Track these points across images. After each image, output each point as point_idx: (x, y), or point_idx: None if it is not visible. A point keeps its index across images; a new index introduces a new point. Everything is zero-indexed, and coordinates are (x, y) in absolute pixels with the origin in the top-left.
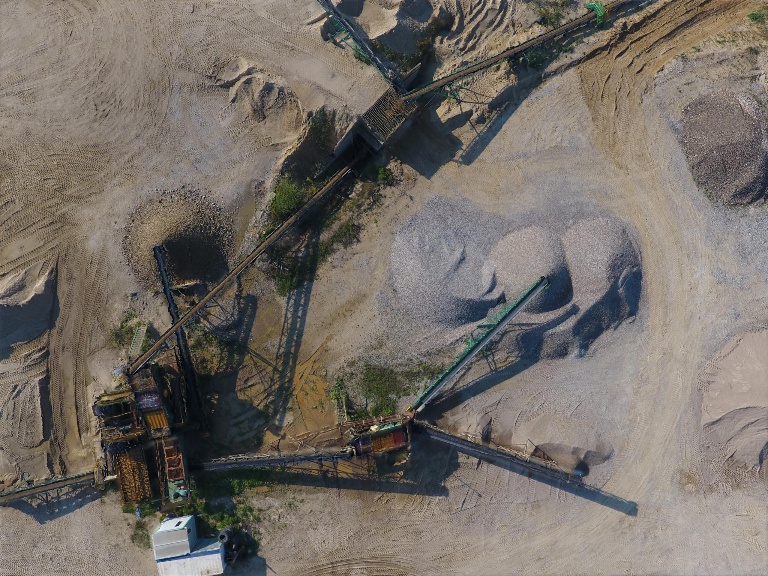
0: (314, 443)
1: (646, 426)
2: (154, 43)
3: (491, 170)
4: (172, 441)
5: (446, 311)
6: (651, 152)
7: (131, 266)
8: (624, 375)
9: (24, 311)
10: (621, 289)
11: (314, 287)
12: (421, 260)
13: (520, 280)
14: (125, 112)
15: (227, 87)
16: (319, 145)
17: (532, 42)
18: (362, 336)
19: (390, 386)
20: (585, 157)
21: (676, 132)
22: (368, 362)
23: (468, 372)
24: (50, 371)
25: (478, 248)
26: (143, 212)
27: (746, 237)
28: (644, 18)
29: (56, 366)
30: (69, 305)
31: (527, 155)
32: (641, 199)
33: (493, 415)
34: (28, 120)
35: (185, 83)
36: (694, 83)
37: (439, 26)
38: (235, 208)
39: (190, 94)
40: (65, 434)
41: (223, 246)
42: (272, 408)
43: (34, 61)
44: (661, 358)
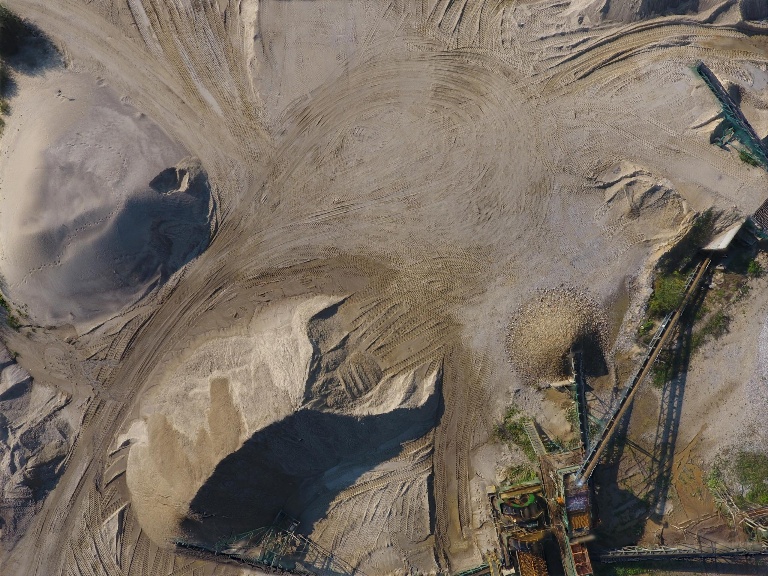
0: (696, 531)
1: None
2: (537, 148)
3: None
4: (576, 537)
5: None
6: None
7: (514, 363)
8: None
9: (420, 412)
10: None
11: (688, 378)
12: None
13: None
14: (507, 215)
15: (604, 188)
16: (694, 241)
17: None
18: (735, 424)
19: (764, 472)
20: None
21: None
22: (742, 449)
23: None
24: (435, 467)
25: None
26: (526, 311)
27: None
28: None
29: (440, 462)
30: (453, 403)
31: None
32: None
33: None
34: (413, 225)
35: (565, 185)
36: None
37: None
38: (610, 304)
39: (569, 195)
40: (447, 527)
41: (601, 341)
42: (652, 497)
43: (419, 168)
44: None
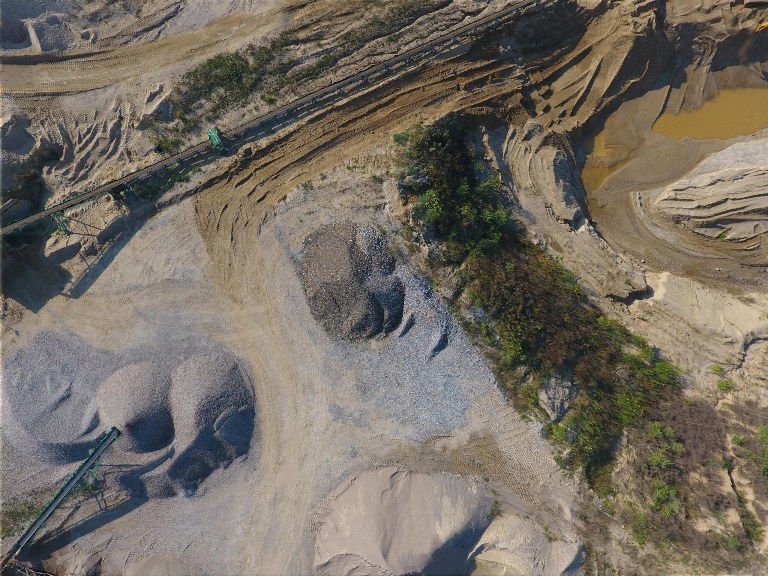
0: None
1: (256, 568)
2: None
3: (100, 304)
4: None
5: (42, 453)
6: (267, 285)
7: None
8: (235, 515)
9: None
10: (217, 432)
11: None
12: (13, 401)
13: (111, 423)
14: None
15: None
16: None
17: (134, 175)
18: None
19: None
20: (198, 290)
21: (295, 264)
22: None
23: (77, 511)
24: None
25: (86, 384)
26: None
27: (367, 371)
28: (271, 143)
29: None
30: None
31: (138, 288)
32: (256, 333)
33: (103, 555)
34: None
35: None
36: (316, 212)
37: (40, 158)
38: None
39: None
40: None
41: None
42: None
43: None
44: (273, 498)
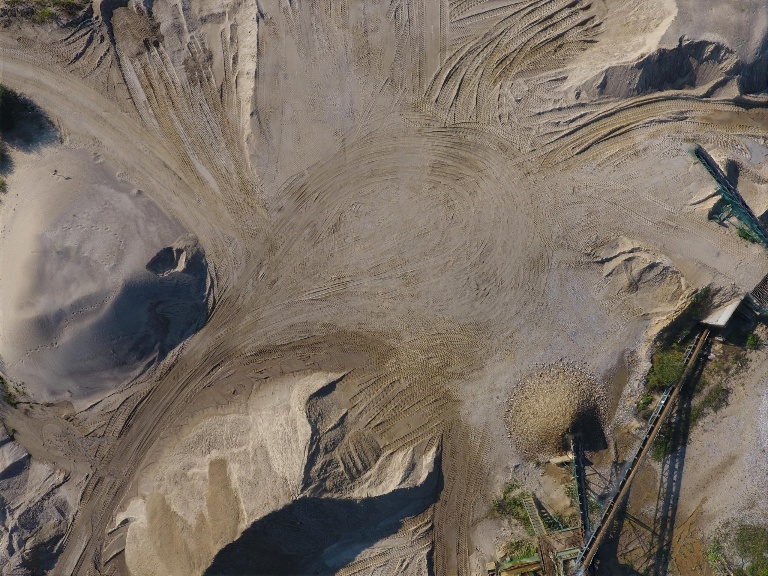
0: None
1: None
2: (535, 224)
3: None
4: None
5: None
6: None
7: (513, 439)
8: None
9: (419, 490)
10: None
11: (687, 451)
12: None
13: None
14: (505, 290)
15: (602, 262)
16: (692, 315)
17: None
18: (735, 497)
19: (764, 545)
20: None
21: None
22: (742, 522)
23: None
24: (434, 543)
25: None
26: (524, 386)
27: None
28: None
29: (440, 537)
30: (453, 478)
31: None
32: None
33: None
34: (411, 301)
35: (563, 260)
36: None
37: None
38: (609, 377)
39: (567, 271)
40: None
41: (600, 415)
42: (652, 571)
43: (416, 244)
44: None
